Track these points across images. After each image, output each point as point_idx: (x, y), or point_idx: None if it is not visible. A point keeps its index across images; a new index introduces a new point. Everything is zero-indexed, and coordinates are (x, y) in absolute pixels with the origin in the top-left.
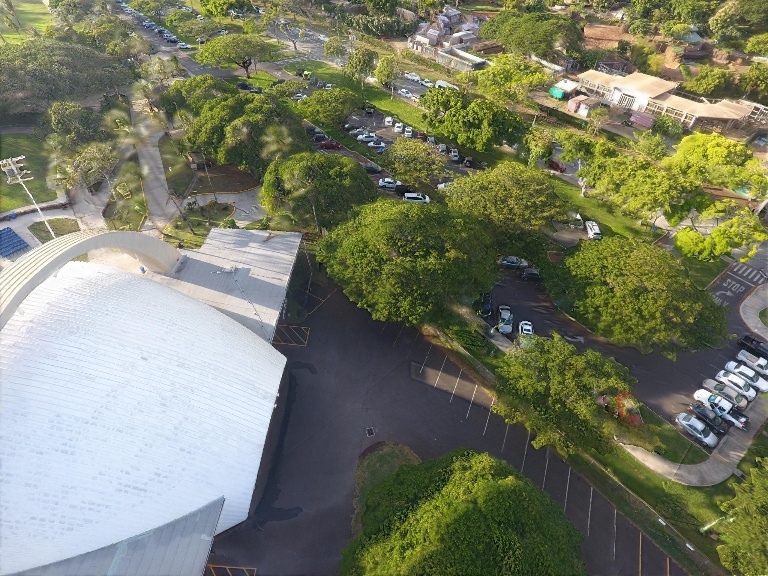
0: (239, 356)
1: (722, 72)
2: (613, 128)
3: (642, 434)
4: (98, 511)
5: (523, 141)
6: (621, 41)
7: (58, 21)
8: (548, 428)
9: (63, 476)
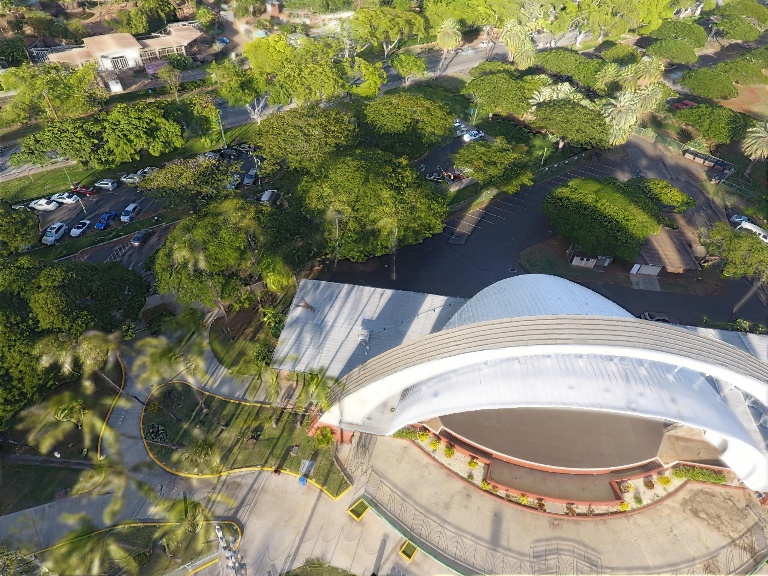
0: (530, 280)
1: (138, 9)
2: (155, 85)
3: (519, 147)
4: None
5: (196, 115)
6: (9, 21)
7: None
8: (525, 173)
9: None
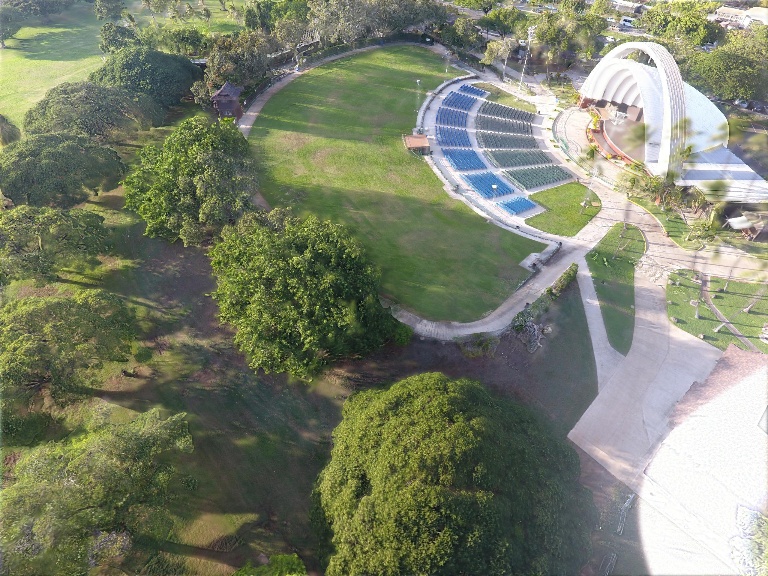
0: None
1: None
2: None
3: None
4: (697, 134)
5: (726, 37)
6: None
7: None
8: None
9: (690, 117)
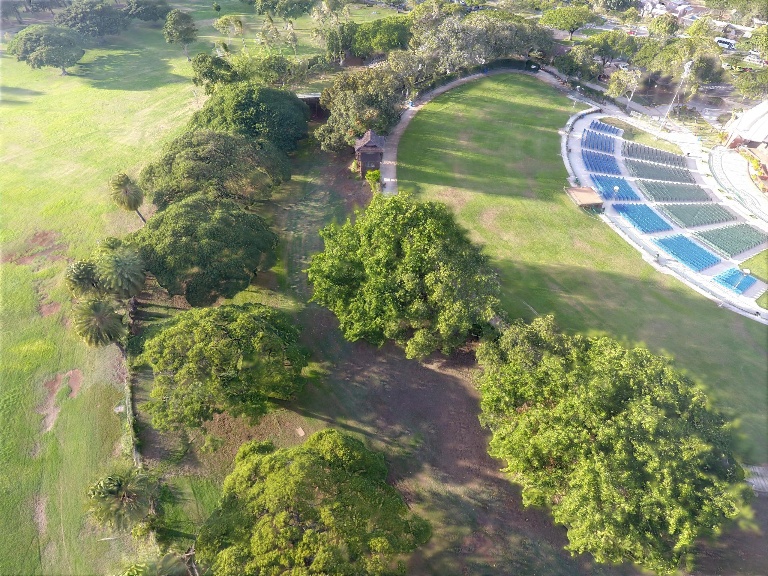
0: None
1: None
2: None
3: None
4: None
5: None
6: None
7: (351, 6)
8: None
9: None
